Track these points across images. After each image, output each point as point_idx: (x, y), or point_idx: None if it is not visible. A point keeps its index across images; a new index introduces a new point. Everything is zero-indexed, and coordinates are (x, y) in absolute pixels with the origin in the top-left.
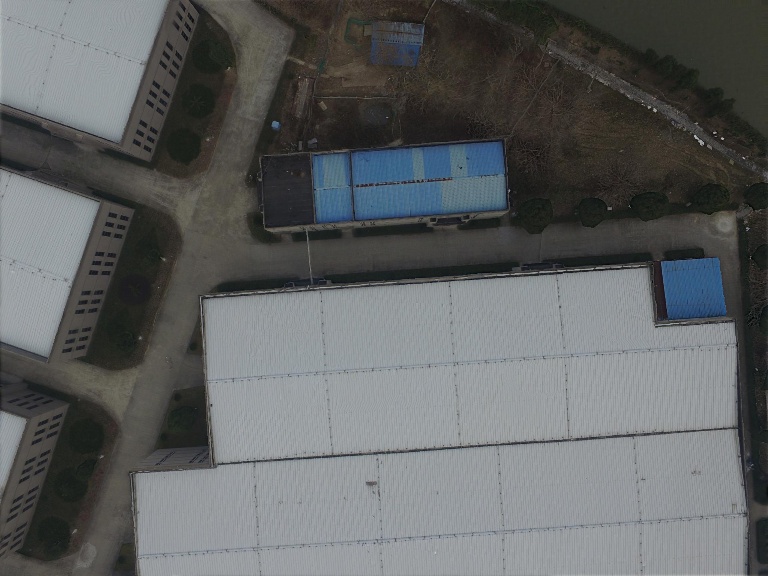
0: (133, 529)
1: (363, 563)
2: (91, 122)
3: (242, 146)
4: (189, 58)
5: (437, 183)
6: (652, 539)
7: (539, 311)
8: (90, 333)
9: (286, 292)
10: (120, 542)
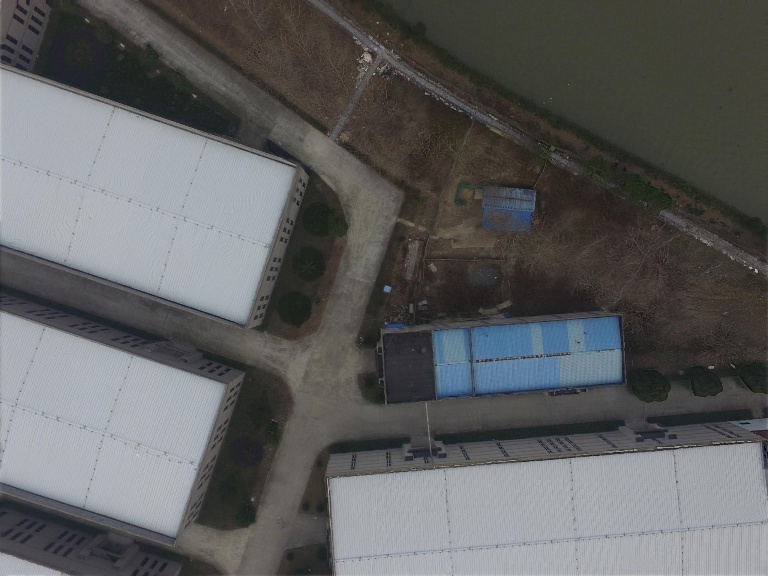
0: None
1: None
2: (214, 303)
3: (352, 308)
4: (299, 221)
5: (555, 358)
6: None
7: (657, 486)
8: (203, 496)
9: (410, 470)
10: None
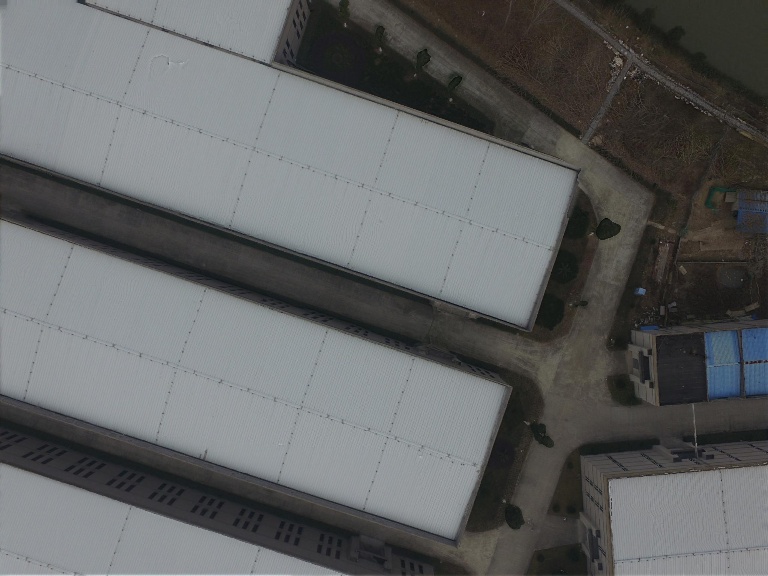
0: None
1: None
2: (495, 306)
3: (603, 310)
4: None
5: None
6: None
7: None
8: None
9: (687, 472)
10: None
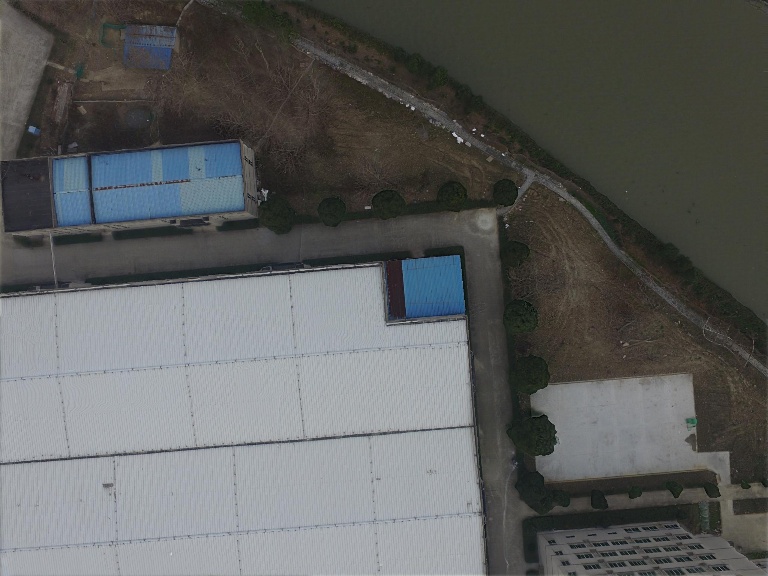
0: None
1: (100, 565)
2: None
3: (4, 151)
4: None
5: (175, 185)
6: (388, 539)
7: (271, 311)
8: None
9: (21, 296)
10: None
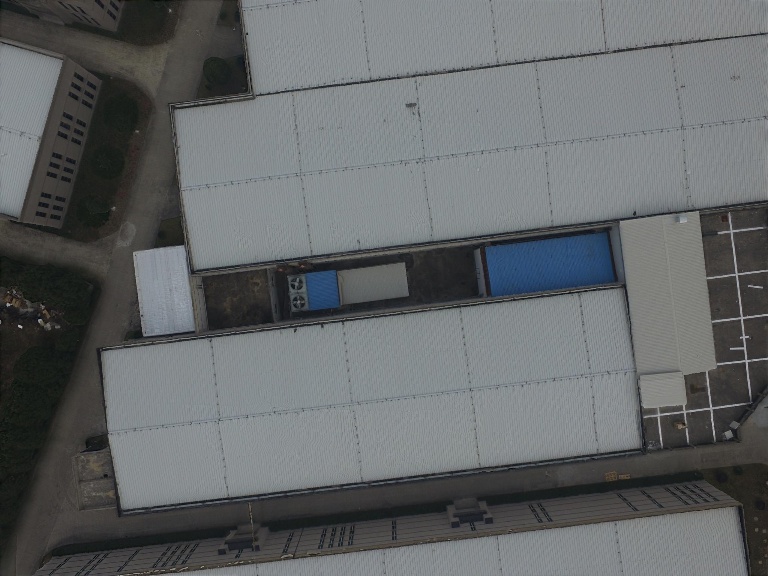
0: (175, 161)
1: (407, 184)
2: None
3: None
4: None
5: None
6: (695, 145)
7: None
8: (120, 6)
9: None
10: (159, 219)
